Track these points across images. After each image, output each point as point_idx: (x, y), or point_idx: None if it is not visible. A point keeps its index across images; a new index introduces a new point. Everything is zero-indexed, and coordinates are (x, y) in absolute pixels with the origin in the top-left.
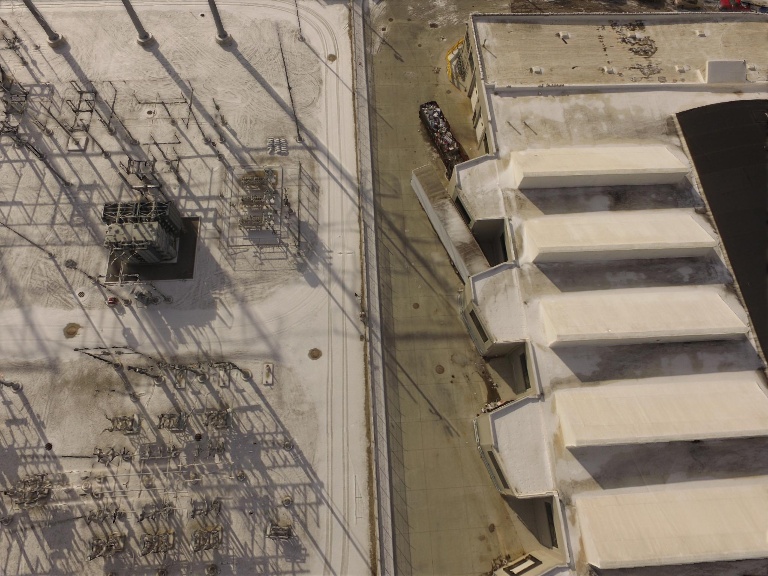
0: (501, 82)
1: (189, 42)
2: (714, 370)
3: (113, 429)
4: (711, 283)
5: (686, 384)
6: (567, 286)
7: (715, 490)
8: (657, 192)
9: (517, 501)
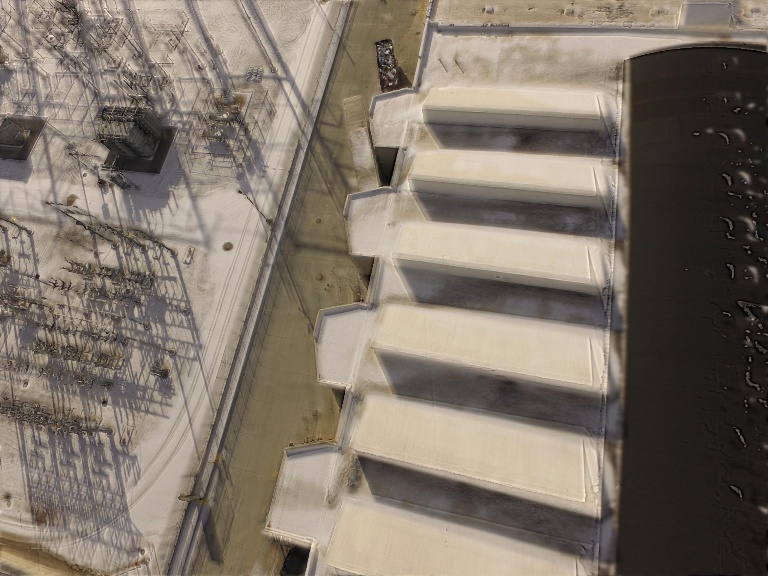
0: (448, 21)
1: None
2: (549, 317)
3: (71, 270)
4: (585, 235)
5: (512, 323)
6: (434, 216)
7: (498, 422)
8: (566, 139)
9: (343, 397)
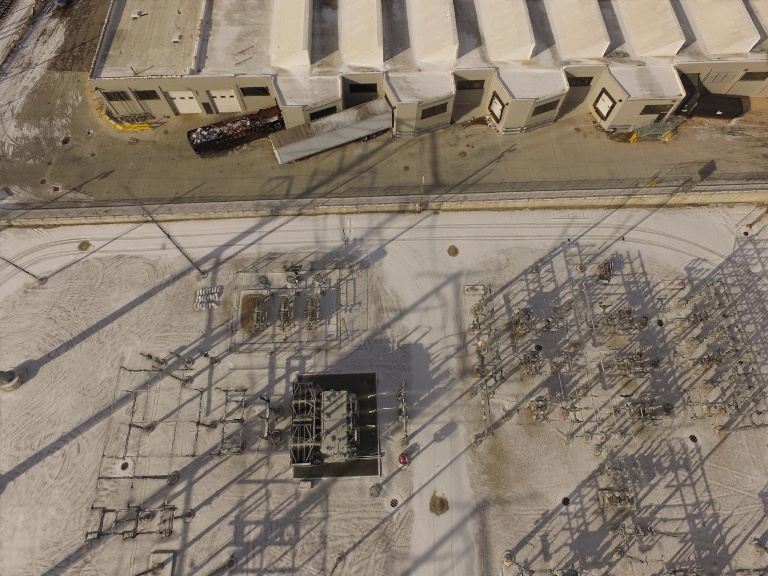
0: (186, 65)
1: (3, 429)
2: None
3: None
4: None
5: None
6: (405, 44)
7: None
8: None
9: None
